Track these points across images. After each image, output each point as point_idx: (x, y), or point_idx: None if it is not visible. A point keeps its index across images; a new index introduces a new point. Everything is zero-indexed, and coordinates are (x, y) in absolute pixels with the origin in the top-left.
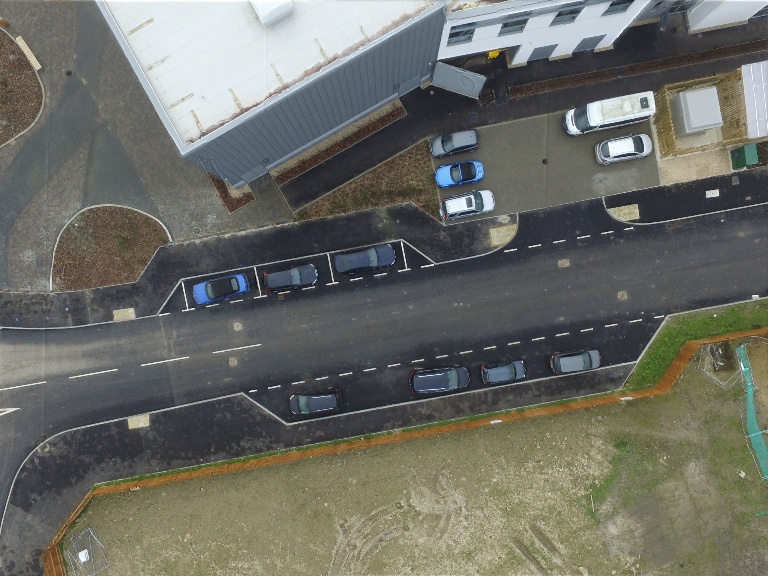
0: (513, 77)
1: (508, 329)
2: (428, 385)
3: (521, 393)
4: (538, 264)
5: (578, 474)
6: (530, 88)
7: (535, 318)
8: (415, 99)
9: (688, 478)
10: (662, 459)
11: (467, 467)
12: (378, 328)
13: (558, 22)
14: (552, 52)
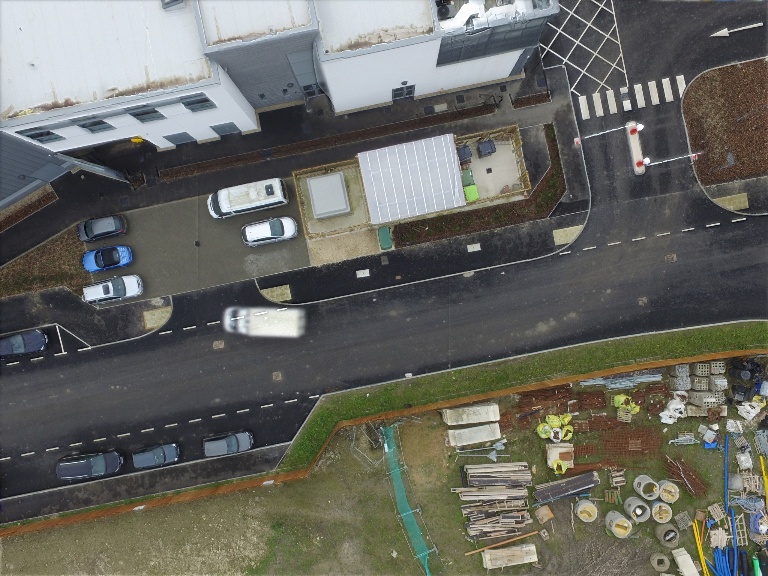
0: (163, 161)
1: (165, 411)
2: (70, 473)
3: (178, 476)
4: (193, 346)
5: (235, 556)
6: (179, 171)
7: (191, 400)
8: (66, 184)
9: (342, 558)
10: (315, 540)
11: (125, 551)
12: (36, 413)
13: (149, 119)
14: (192, 137)
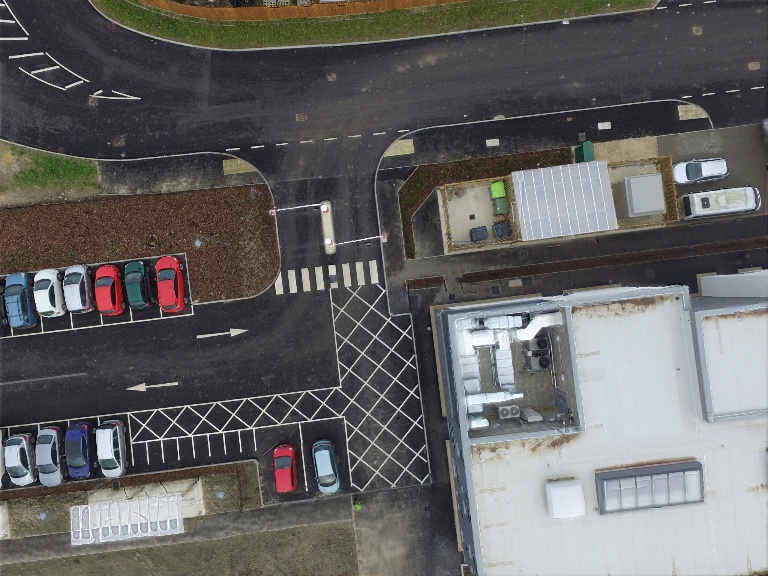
0: None
1: None
2: None
3: None
4: None
5: None
6: None
7: None
8: None
9: None
10: None
11: None
12: None
13: None
14: None
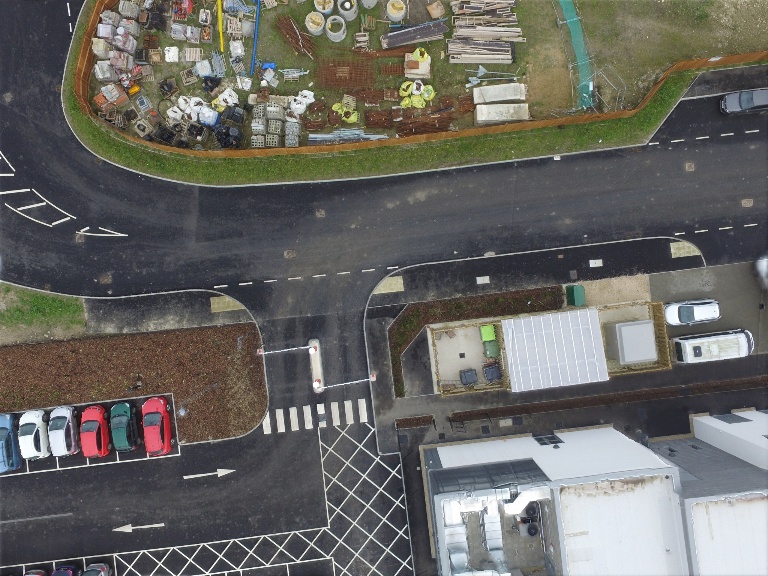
0: None
1: None
2: None
3: None
4: None
5: None
6: None
7: None
8: None
9: None
10: None
11: None
12: None
13: None
14: None
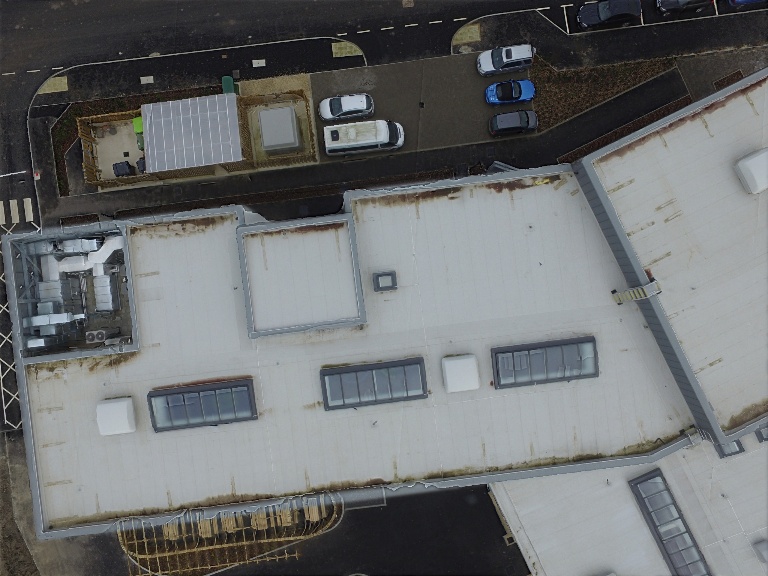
0: None
1: None
2: None
3: None
4: (434, 4)
5: None
6: (434, 177)
7: None
8: None
9: None
10: None
11: None
12: None
13: None
14: None
